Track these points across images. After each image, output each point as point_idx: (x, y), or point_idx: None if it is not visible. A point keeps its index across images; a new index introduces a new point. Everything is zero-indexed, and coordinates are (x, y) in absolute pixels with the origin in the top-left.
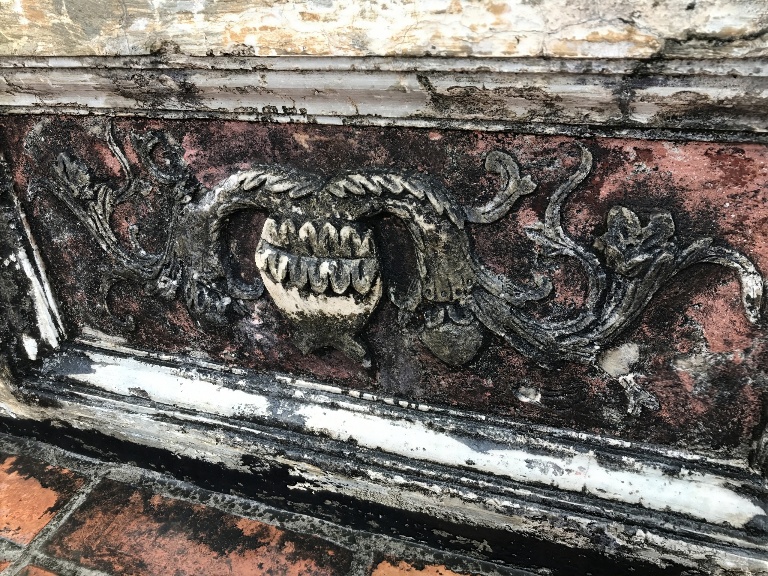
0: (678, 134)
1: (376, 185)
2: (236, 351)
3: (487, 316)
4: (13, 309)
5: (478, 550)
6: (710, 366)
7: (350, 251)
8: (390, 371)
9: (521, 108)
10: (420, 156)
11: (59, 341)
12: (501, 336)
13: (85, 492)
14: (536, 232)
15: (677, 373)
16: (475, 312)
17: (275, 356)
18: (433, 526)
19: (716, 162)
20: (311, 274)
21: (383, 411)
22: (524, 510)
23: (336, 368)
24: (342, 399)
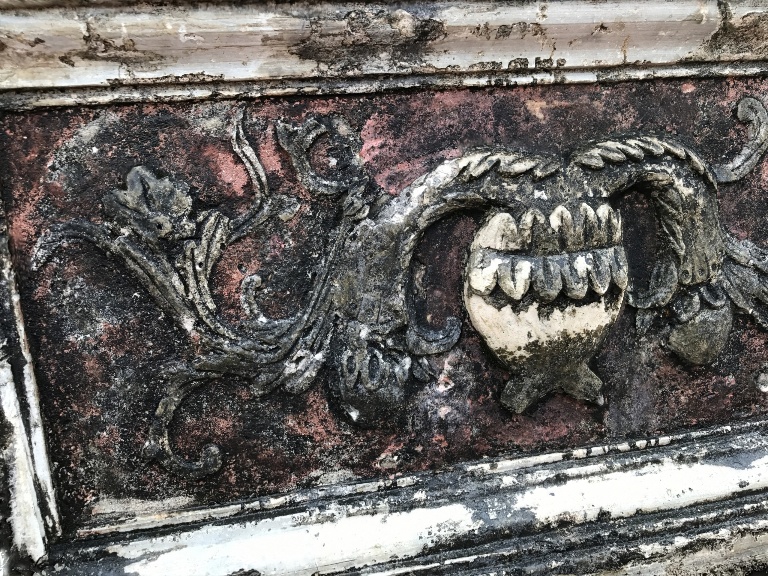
0: None
1: (636, 148)
2: (402, 449)
3: (738, 291)
4: None
5: None
6: None
7: (607, 237)
8: (620, 405)
9: None
10: (670, 114)
11: (45, 544)
12: (747, 314)
13: None
14: None
15: None
16: (727, 289)
17: (465, 436)
18: None
19: None
20: (568, 275)
21: (623, 461)
22: None
23: (551, 425)
24: (567, 465)
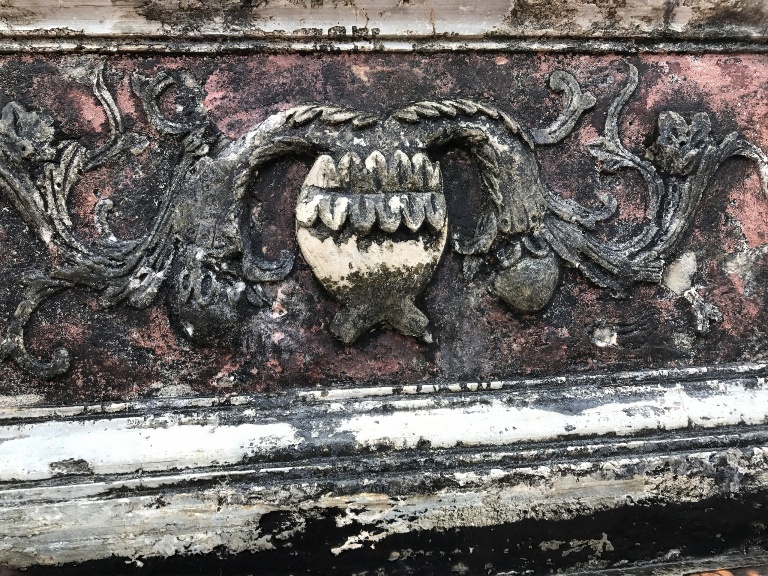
0: (699, 46)
1: (450, 107)
2: (238, 370)
3: (561, 244)
4: None
5: (597, 554)
6: (752, 263)
7: (422, 182)
8: (452, 347)
9: (586, 21)
10: (486, 82)
11: None
12: (574, 268)
13: None
14: (597, 148)
15: (729, 277)
16: (550, 241)
17: (298, 363)
18: (541, 537)
19: (725, 70)
20: (381, 210)
21: (451, 399)
22: (645, 463)
23: (383, 361)
24: (396, 398)
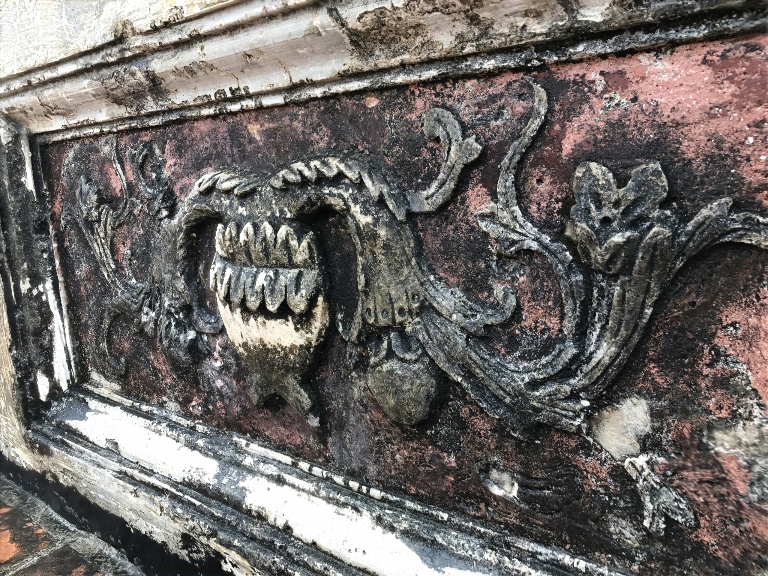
0: (655, 35)
1: (312, 170)
2: (202, 403)
3: (438, 349)
4: (33, 341)
5: None
6: None
7: (287, 257)
8: (342, 436)
9: (446, 34)
10: (360, 131)
11: (70, 384)
12: (459, 382)
13: (40, 555)
14: (489, 219)
15: (717, 457)
16: (423, 343)
17: (234, 410)
18: None
19: (722, 72)
20: (247, 286)
21: (329, 492)
22: None
23: (289, 429)
24: (290, 472)
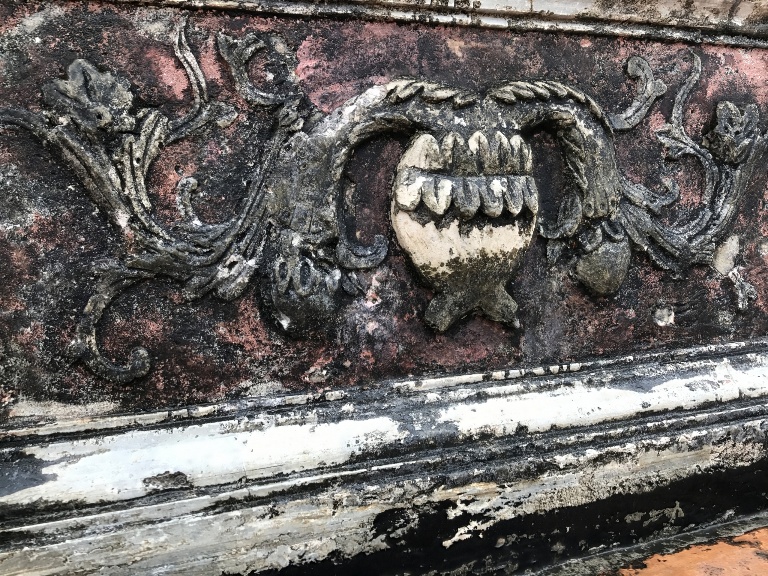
0: (751, 40)
1: (543, 88)
2: (331, 363)
3: (634, 228)
4: None
5: (671, 521)
6: None
7: (519, 165)
8: (535, 331)
9: (666, 9)
10: (571, 64)
11: None
12: (643, 251)
13: None
14: (665, 134)
15: (763, 258)
16: (625, 226)
17: (392, 353)
18: (627, 510)
19: None
20: (485, 193)
21: (539, 383)
22: (712, 434)
23: (471, 347)
24: (487, 385)
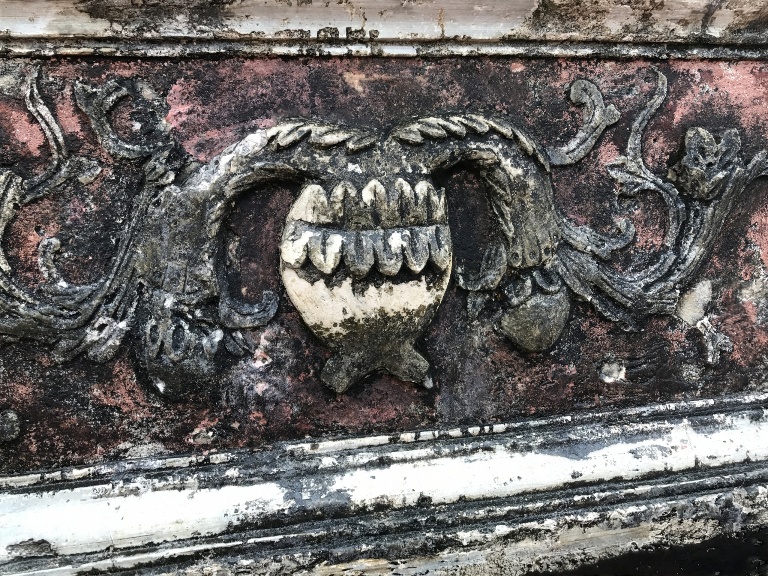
0: (735, 52)
1: (458, 125)
2: (217, 424)
3: (574, 277)
4: None
5: None
6: (767, 289)
7: (426, 214)
8: (453, 389)
9: (617, 24)
10: (499, 93)
11: None
12: (586, 302)
13: None
14: (618, 168)
15: (743, 304)
16: (562, 275)
17: (285, 414)
18: None
19: (759, 79)
20: (380, 250)
21: (452, 447)
22: (652, 510)
23: (378, 407)
24: (393, 449)
